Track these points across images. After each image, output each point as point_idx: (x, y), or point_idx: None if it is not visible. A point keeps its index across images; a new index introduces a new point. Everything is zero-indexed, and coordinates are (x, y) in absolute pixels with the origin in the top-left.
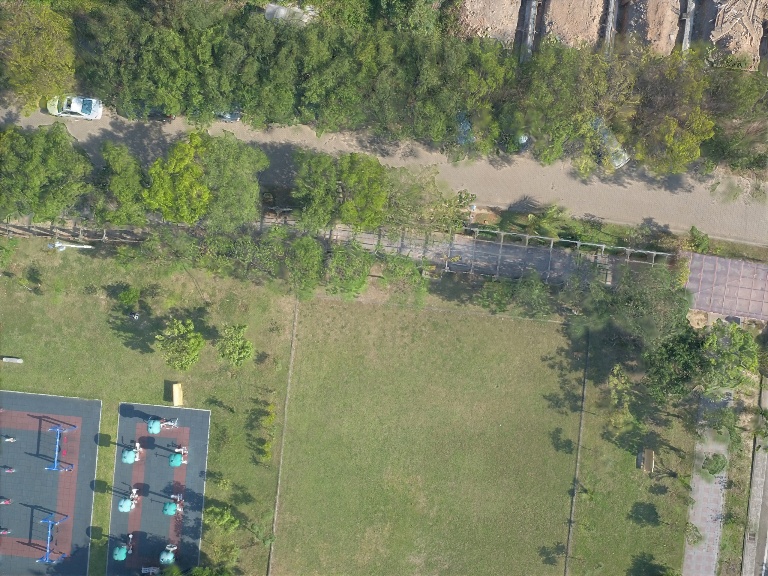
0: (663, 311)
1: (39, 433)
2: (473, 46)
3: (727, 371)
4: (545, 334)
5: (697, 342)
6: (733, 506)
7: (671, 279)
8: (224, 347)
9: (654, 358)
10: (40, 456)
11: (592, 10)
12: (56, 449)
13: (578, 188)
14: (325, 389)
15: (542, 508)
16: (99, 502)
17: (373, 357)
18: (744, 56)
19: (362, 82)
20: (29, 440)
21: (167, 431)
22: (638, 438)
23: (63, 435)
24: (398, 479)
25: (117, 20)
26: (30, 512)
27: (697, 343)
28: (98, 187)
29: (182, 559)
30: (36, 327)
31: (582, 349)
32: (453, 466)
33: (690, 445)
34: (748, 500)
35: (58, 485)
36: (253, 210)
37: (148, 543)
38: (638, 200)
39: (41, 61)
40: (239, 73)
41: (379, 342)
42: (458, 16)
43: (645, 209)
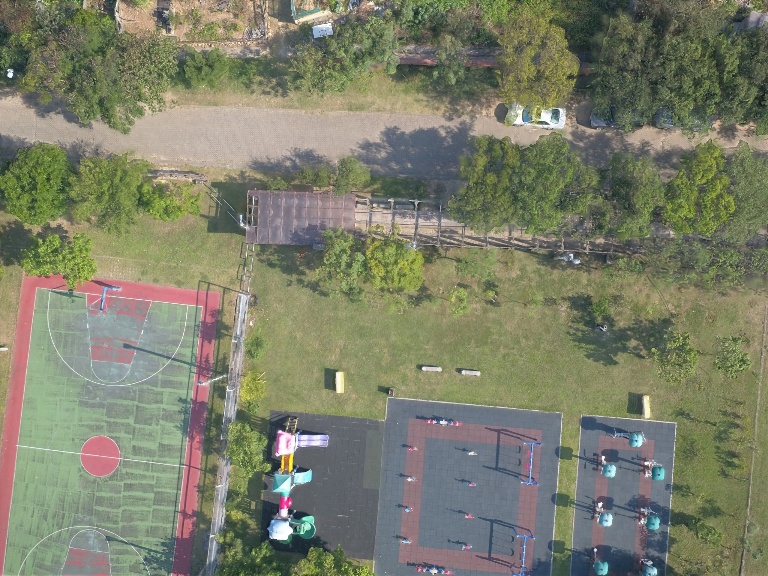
0: None
1: (498, 446)
2: None
3: None
4: None
5: None
6: None
7: None
8: (726, 360)
9: None
10: (499, 469)
11: None
12: (531, 463)
13: None
14: None
15: None
16: (561, 516)
17: None
18: None
19: None
20: (487, 453)
21: None
22: None
23: (523, 448)
24: None
25: (626, 29)
26: (490, 526)
27: None
28: (603, 198)
29: None
30: (493, 339)
31: None
32: None
33: None
34: None
35: (519, 499)
36: None
37: (613, 557)
38: None
39: (549, 71)
40: (765, 82)
41: None
42: None
43: None
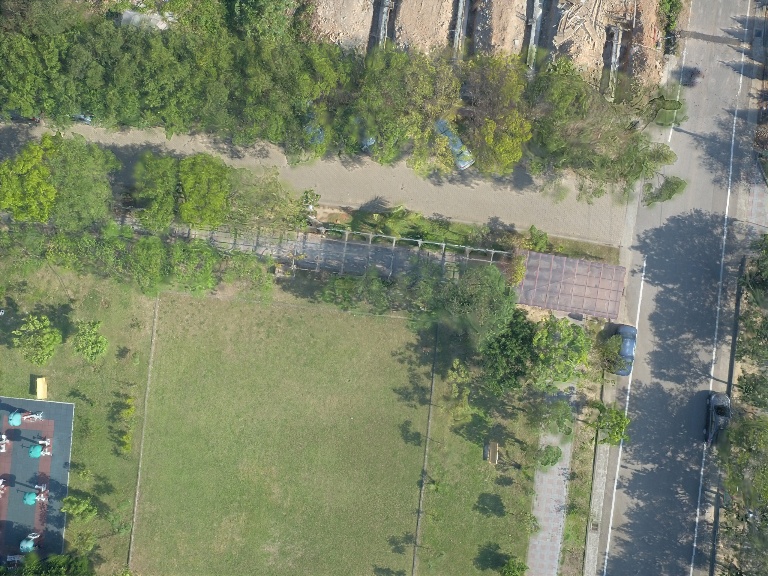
0: (483, 307)
1: None
2: (312, 51)
3: (554, 365)
4: (395, 330)
5: (531, 337)
6: (576, 497)
7: (508, 276)
8: (77, 342)
9: (489, 353)
10: None
11: (440, 16)
12: None
13: (427, 188)
14: (184, 383)
15: (392, 499)
16: None
17: (230, 352)
18: (586, 60)
19: (201, 86)
20: None
21: (33, 424)
22: (485, 431)
23: None
24: (253, 470)
25: None
26: None
27: (531, 338)
28: None
29: (46, 547)
30: None
31: (431, 344)
32: (306, 458)
33: (535, 438)
34: (590, 491)
35: None
36: (103, 210)
37: (14, 532)
38: (485, 200)
39: None
40: (85, 78)
41: (236, 338)
42: (310, 22)
43: (491, 209)
